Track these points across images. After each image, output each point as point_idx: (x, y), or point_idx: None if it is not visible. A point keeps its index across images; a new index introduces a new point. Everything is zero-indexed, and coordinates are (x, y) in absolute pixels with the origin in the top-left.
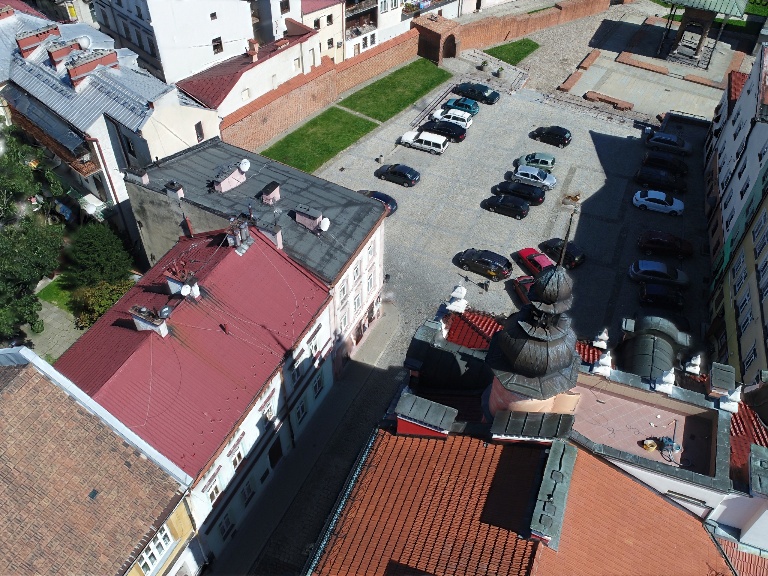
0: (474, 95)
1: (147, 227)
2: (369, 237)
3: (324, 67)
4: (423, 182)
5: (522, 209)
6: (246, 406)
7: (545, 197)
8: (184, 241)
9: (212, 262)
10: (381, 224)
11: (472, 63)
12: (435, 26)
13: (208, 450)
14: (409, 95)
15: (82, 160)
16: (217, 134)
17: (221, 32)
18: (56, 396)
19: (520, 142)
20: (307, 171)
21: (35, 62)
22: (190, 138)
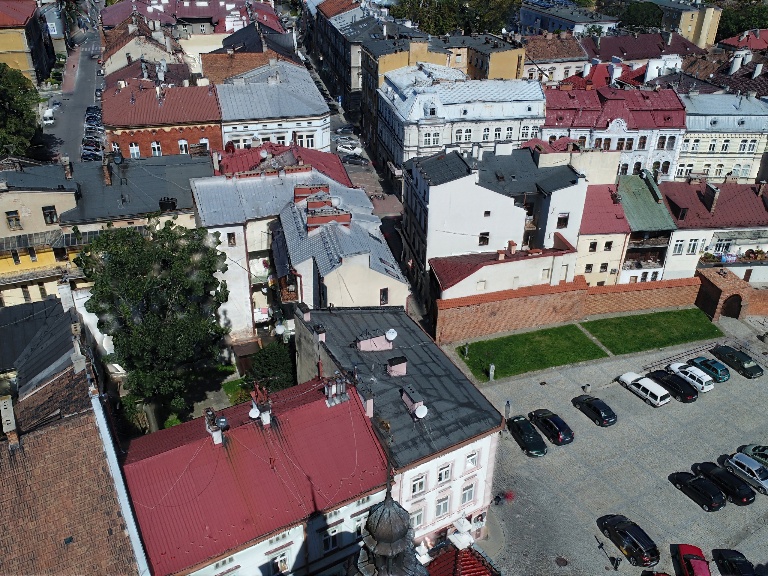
0: (731, 361)
1: (301, 358)
2: (466, 443)
3: (575, 285)
4: (619, 427)
5: (712, 500)
6: (247, 540)
7: (756, 500)
8: (315, 380)
9: (303, 402)
10: (492, 437)
11: (755, 330)
12: (720, 281)
13: (188, 560)
14: (660, 339)
15: (289, 289)
16: (403, 304)
17: (491, 228)
18: (95, 447)
19: (761, 429)
20: (509, 372)
21: (301, 207)
22: (373, 299)
